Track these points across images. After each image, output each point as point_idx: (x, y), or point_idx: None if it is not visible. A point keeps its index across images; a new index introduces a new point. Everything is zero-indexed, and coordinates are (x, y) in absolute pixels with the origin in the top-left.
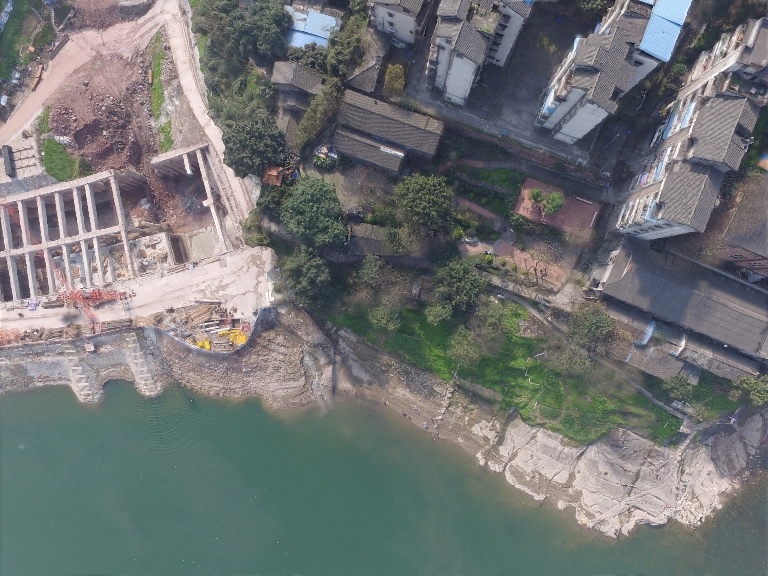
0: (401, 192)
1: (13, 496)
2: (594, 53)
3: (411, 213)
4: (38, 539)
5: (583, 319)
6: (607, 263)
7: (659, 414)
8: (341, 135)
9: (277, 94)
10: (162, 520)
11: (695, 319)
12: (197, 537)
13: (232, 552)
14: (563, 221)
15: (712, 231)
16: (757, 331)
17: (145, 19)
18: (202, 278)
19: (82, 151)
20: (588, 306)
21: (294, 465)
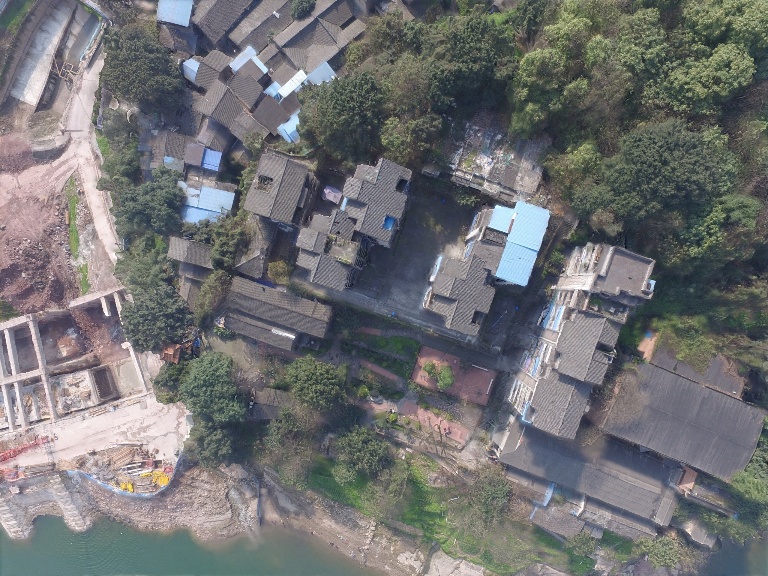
0: (290, 379)
1: None
2: (450, 285)
3: (300, 401)
4: None
5: (480, 488)
6: (505, 427)
7: (573, 555)
8: (232, 318)
9: None
10: None
11: (590, 488)
12: None
13: None
14: (460, 388)
15: (588, 427)
16: (650, 500)
17: (59, 162)
18: (123, 420)
19: (1, 294)
20: (489, 468)
21: None
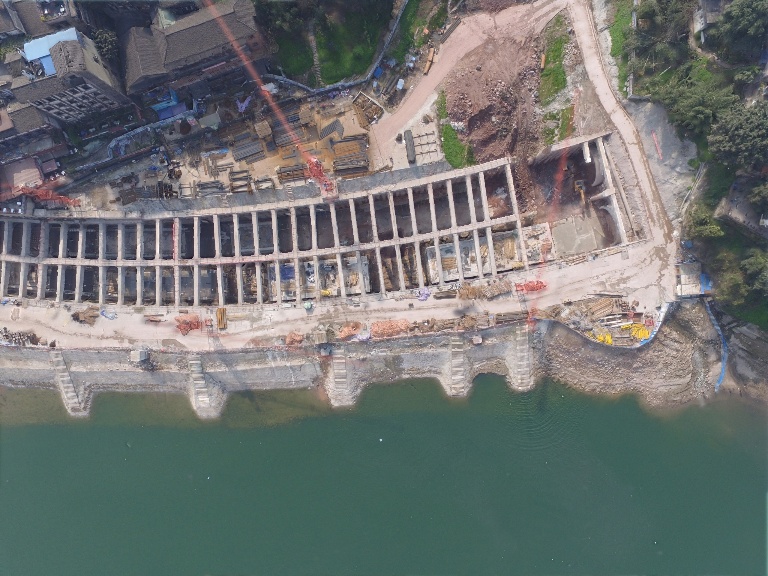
0: None
1: (376, 490)
2: None
3: None
4: (401, 534)
5: None
6: None
7: None
8: None
9: (754, 80)
10: (531, 518)
11: None
12: (568, 536)
13: (605, 552)
14: None
15: None
16: None
17: (542, 2)
18: (602, 270)
19: (470, 138)
20: None
21: (672, 464)
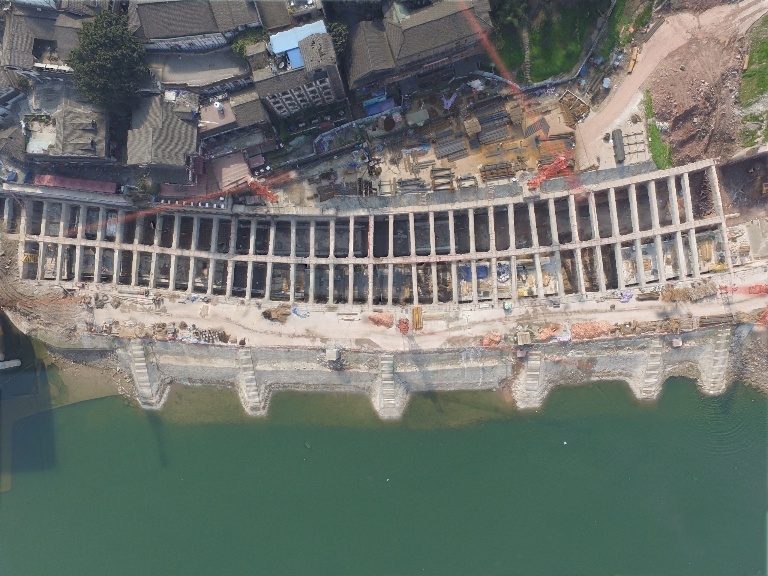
0: None
1: (561, 494)
2: None
3: None
4: (587, 539)
5: None
6: None
7: None
8: None
9: None
10: (720, 523)
11: None
12: (758, 542)
13: None
14: None
15: None
16: None
17: (749, 2)
18: None
19: (671, 138)
20: None
21: None
